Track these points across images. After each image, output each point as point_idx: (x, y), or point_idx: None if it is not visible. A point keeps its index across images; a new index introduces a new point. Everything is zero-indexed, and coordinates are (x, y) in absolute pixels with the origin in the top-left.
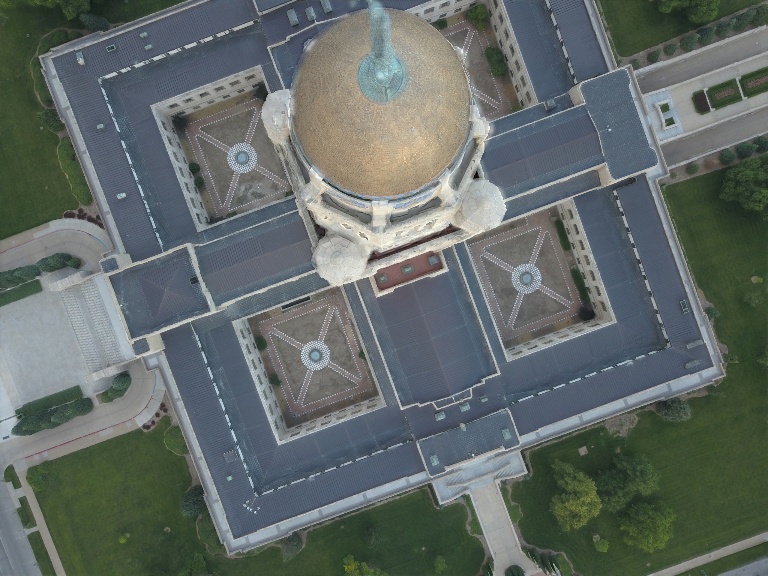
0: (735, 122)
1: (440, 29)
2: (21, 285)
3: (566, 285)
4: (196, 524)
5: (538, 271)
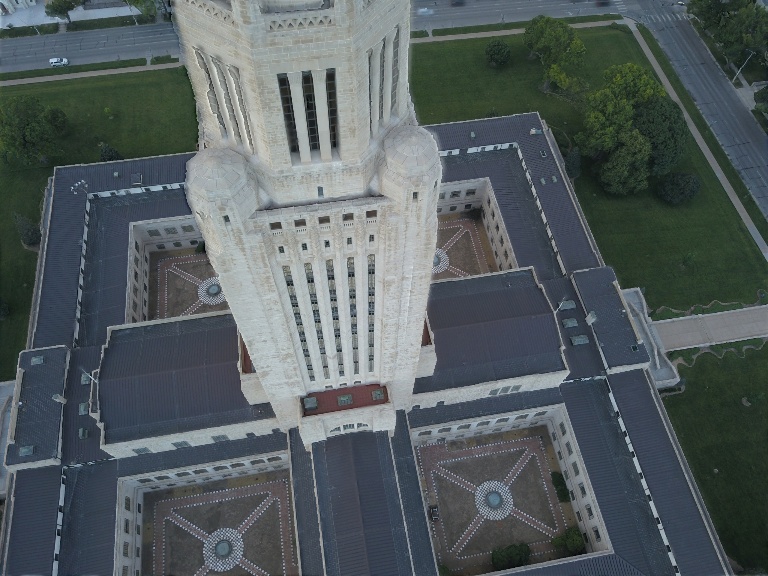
0: None
1: (558, 492)
2: None
3: None
4: None
5: (228, 568)
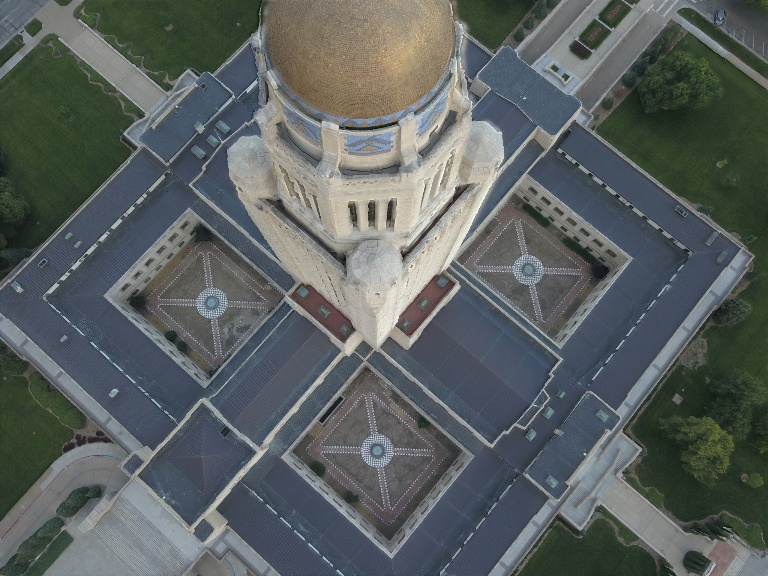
0: (617, 52)
1: None
2: (49, 546)
3: (566, 257)
4: None
5: (534, 258)
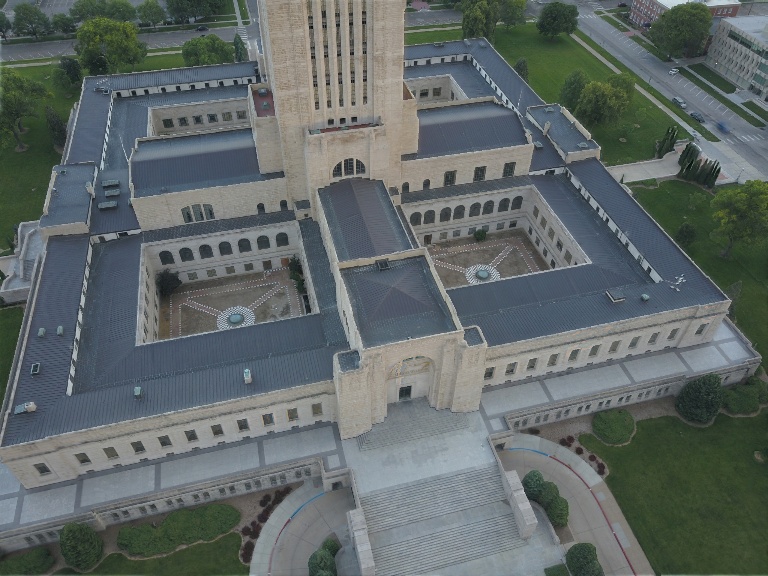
0: None
1: None
2: None
3: None
4: (735, 417)
5: None
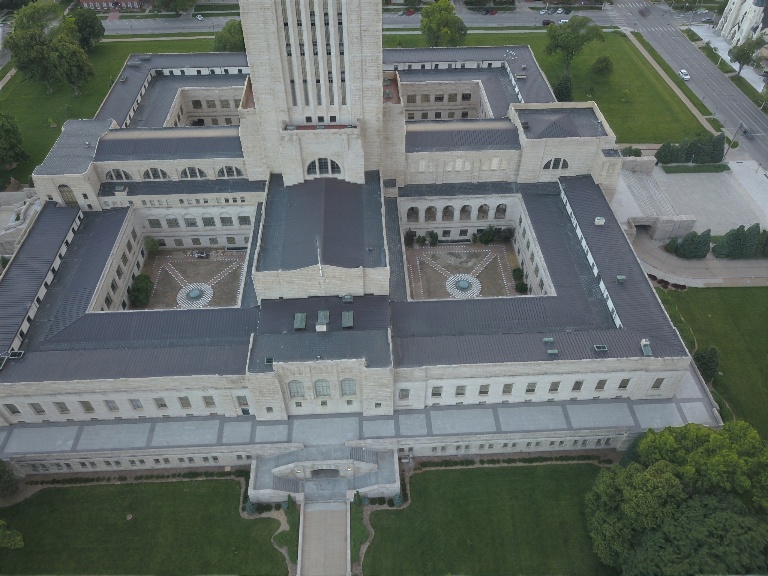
0: None
1: None
2: None
3: None
4: None
5: None
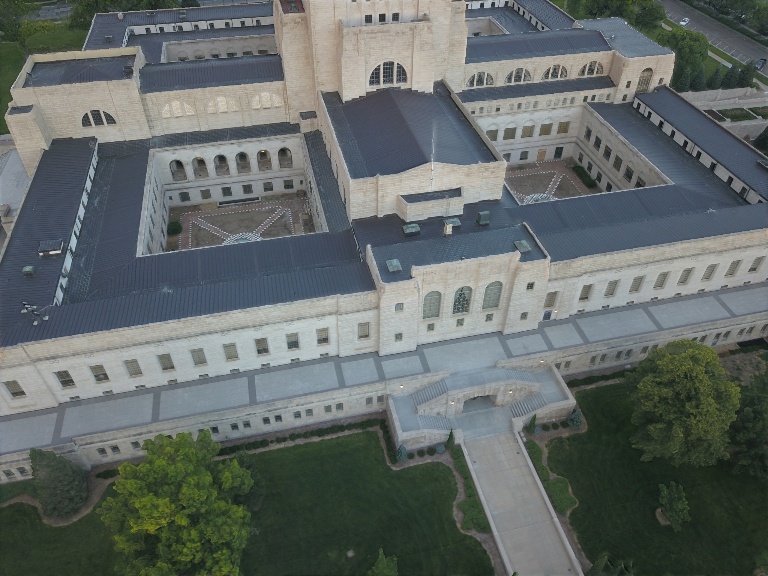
0: None
1: None
2: None
3: None
4: None
5: None
